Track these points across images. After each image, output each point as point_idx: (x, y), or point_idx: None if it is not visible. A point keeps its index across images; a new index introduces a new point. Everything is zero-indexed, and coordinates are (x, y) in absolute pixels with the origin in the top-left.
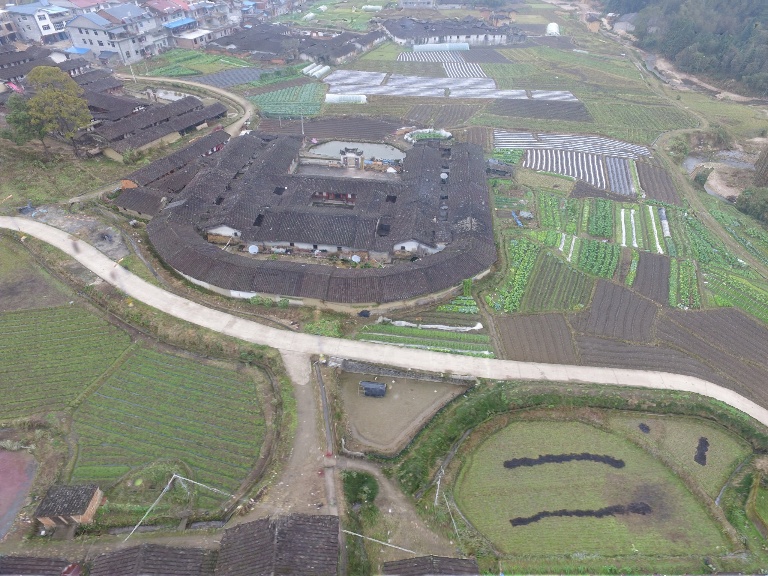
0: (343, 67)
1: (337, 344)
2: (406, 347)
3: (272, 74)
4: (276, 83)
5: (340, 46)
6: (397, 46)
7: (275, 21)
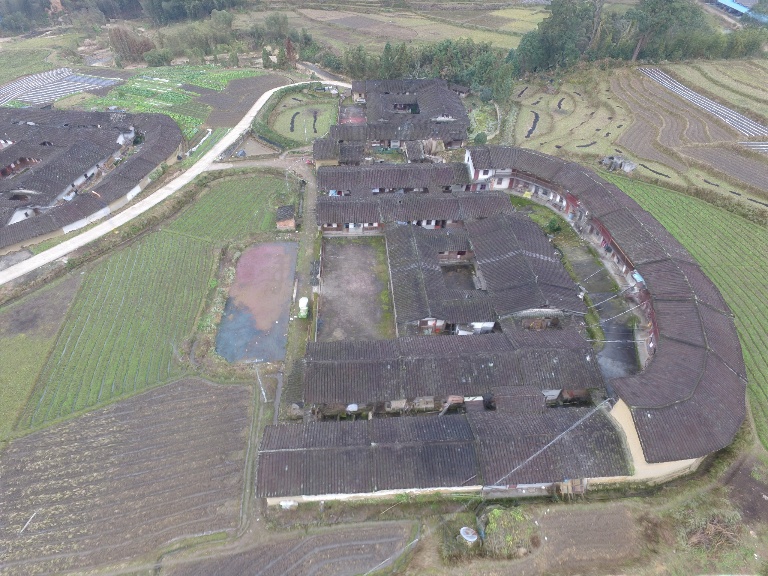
0: None
1: None
2: None
3: None
4: None
5: None
6: None
7: None
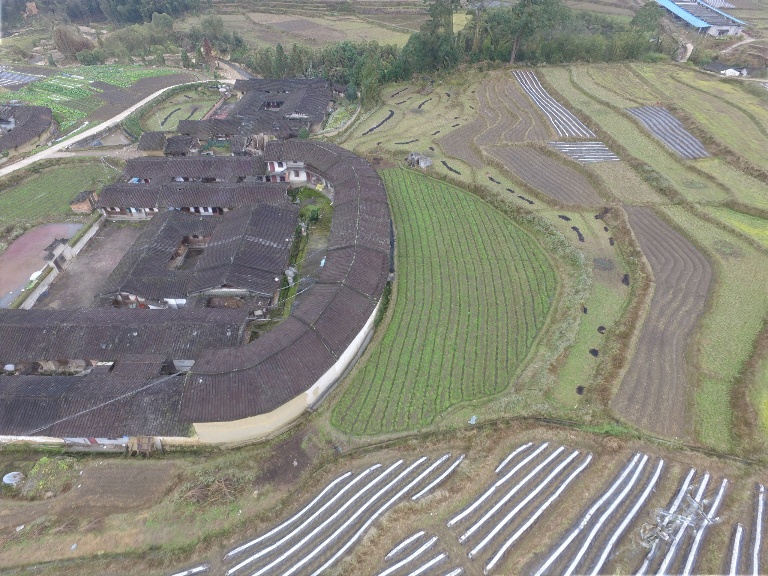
0: None
1: (57, 146)
2: (80, 133)
3: None
4: None
5: None
6: None
7: None
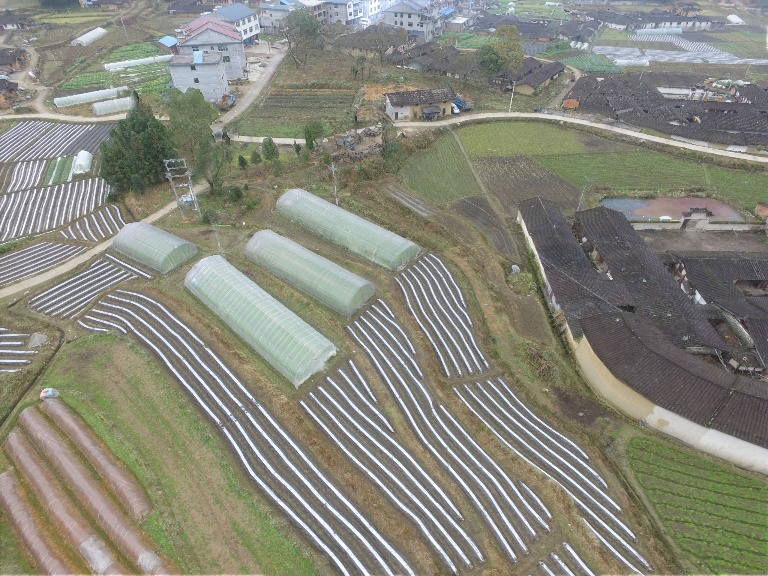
0: (595, 44)
1: None
2: None
3: (554, 47)
4: (560, 53)
5: (576, 30)
6: (618, 31)
7: (491, 13)
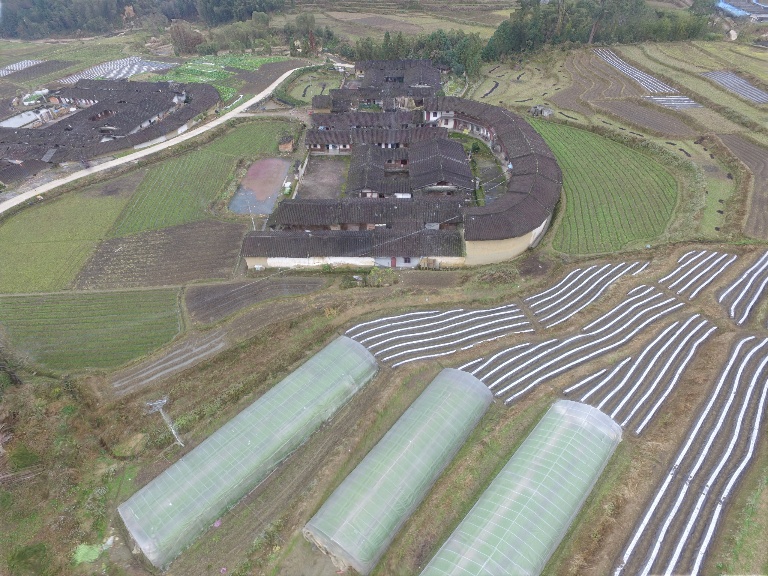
0: None
1: (237, 109)
2: None
3: None
4: None
5: None
6: None
7: None
